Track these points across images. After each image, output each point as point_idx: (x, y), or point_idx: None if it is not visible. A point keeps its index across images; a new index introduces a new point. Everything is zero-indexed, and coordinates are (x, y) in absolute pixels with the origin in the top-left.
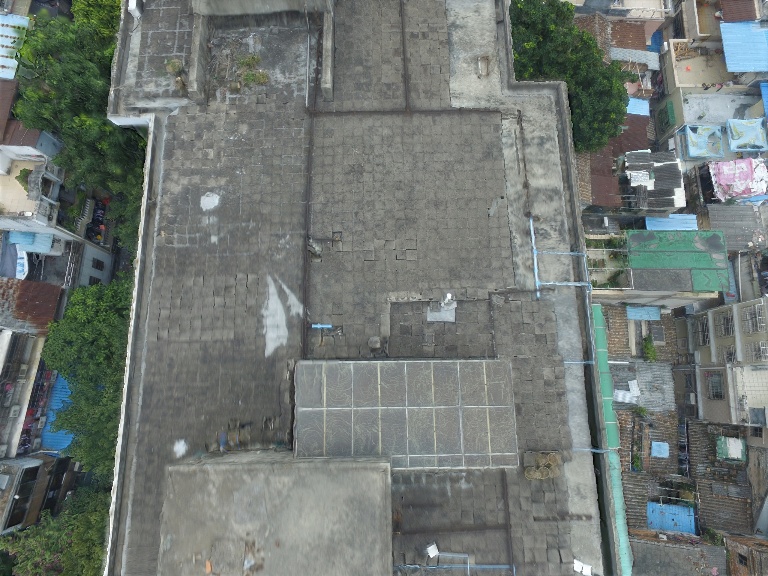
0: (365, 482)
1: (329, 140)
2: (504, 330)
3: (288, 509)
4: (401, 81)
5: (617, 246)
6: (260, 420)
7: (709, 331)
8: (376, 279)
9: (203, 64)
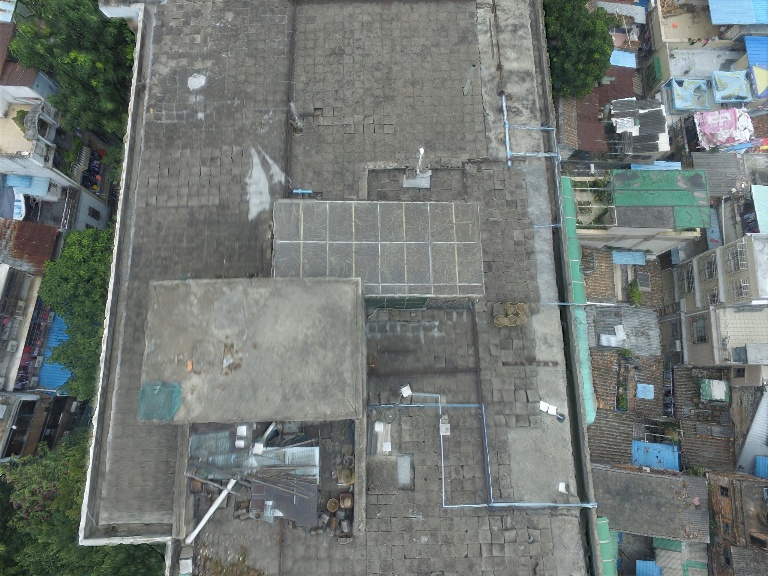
0: (337, 293)
1: (311, 26)
2: (476, 196)
3: (265, 316)
4: None
5: None
6: None
7: (694, 277)
8: (355, 150)
9: None
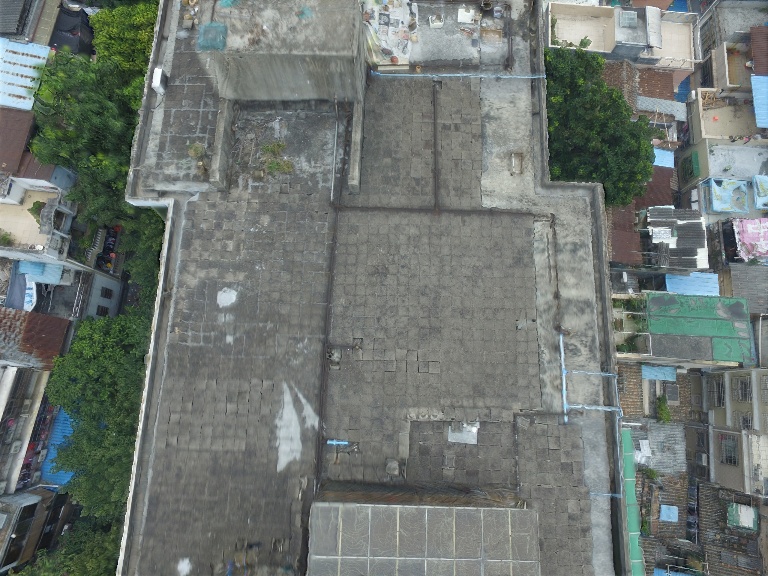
0: None
1: (353, 237)
2: (528, 455)
3: None
4: (431, 176)
5: (636, 307)
6: (269, 541)
7: (725, 393)
8: (396, 392)
9: (226, 150)
